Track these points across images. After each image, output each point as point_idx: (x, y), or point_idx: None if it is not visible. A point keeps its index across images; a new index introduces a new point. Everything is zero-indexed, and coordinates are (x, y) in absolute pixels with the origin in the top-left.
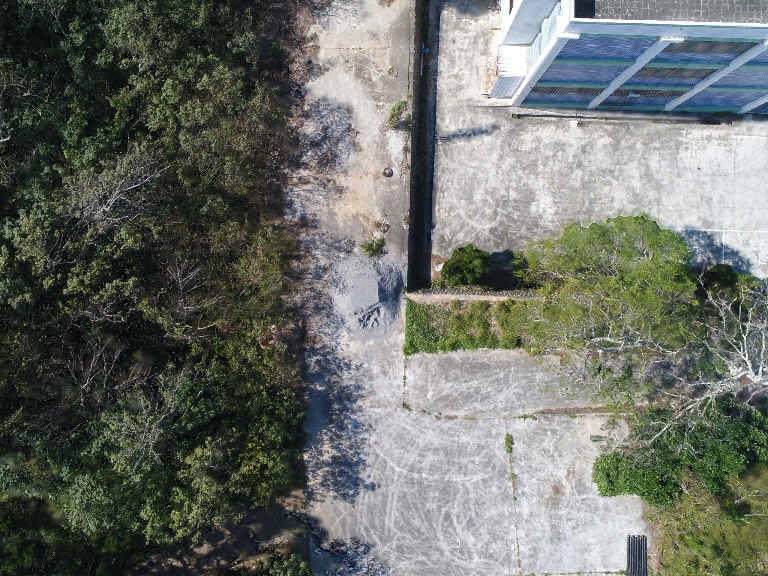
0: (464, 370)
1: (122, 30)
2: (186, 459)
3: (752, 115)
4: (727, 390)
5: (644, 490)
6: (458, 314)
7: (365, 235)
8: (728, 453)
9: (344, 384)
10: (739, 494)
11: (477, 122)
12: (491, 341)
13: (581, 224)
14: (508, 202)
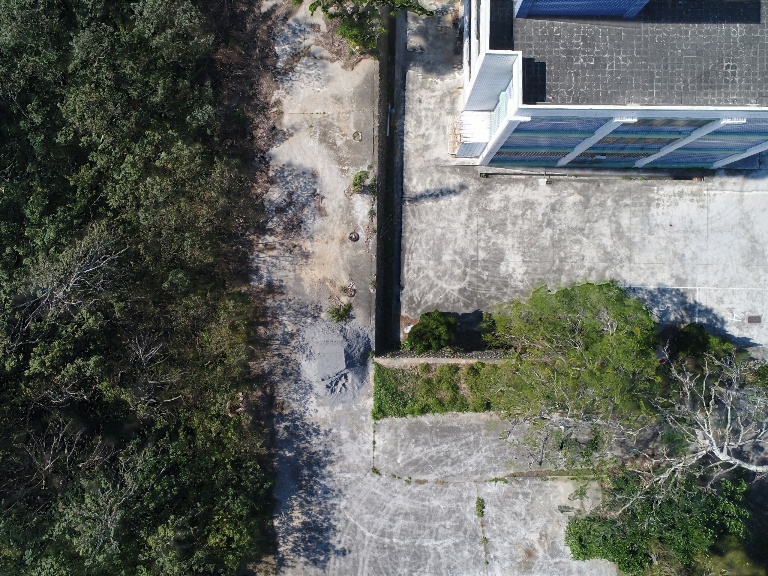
0: (434, 434)
1: (78, 112)
2: (148, 539)
3: (725, 170)
4: (689, 471)
5: (614, 559)
6: (427, 378)
7: (332, 300)
8: (696, 527)
9: (313, 450)
10: (707, 570)
11: (445, 182)
12: (460, 405)
13: (551, 283)
14: (477, 262)
